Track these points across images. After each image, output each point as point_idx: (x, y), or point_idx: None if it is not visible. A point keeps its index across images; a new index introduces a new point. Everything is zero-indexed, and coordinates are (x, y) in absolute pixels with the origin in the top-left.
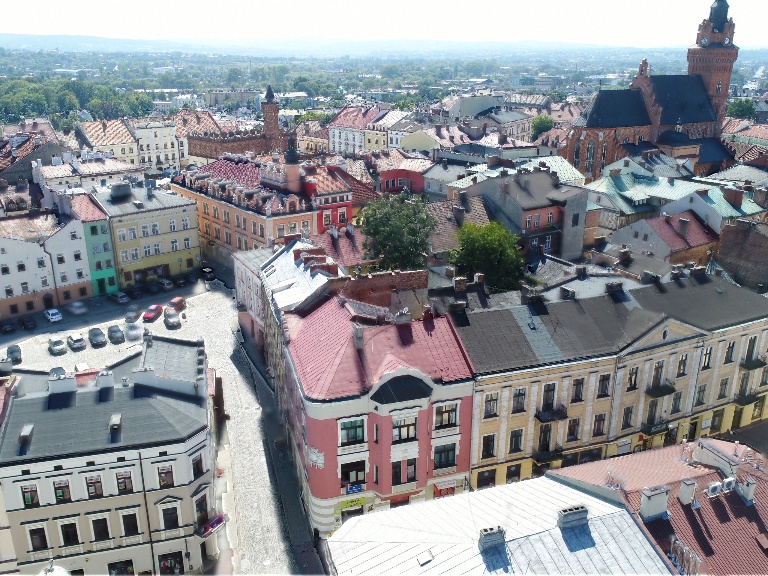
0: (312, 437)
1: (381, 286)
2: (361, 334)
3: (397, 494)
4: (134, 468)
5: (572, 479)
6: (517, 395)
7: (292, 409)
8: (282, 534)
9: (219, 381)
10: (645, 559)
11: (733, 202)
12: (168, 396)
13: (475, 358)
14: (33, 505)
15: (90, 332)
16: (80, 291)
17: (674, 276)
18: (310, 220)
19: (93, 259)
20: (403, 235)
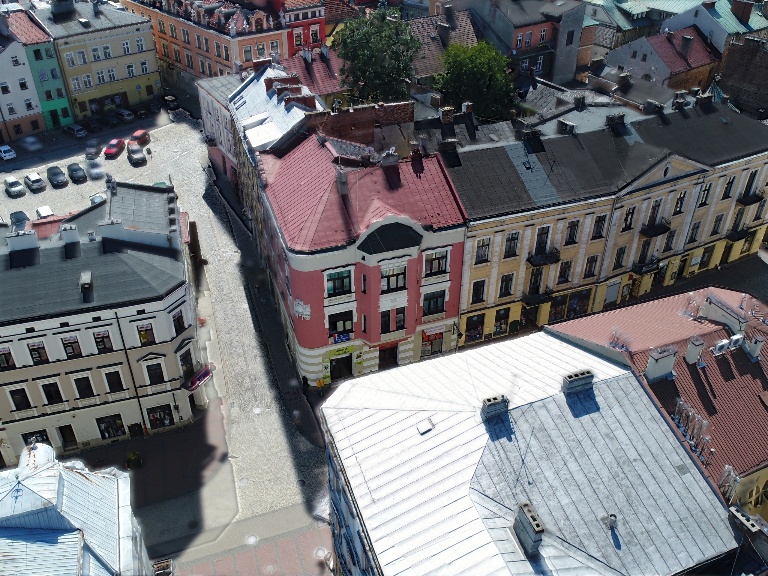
0: (297, 289)
1: (363, 121)
2: (345, 179)
3: (386, 342)
4: (111, 327)
5: (573, 337)
6: (510, 239)
7: (273, 256)
8: (270, 381)
9: (193, 225)
10: (649, 422)
11: (740, 16)
12: (140, 250)
13: (467, 202)
14: (9, 367)
15: (48, 171)
16: (32, 124)
17: (679, 105)
18: (279, 40)
19: (41, 88)
20: (385, 59)
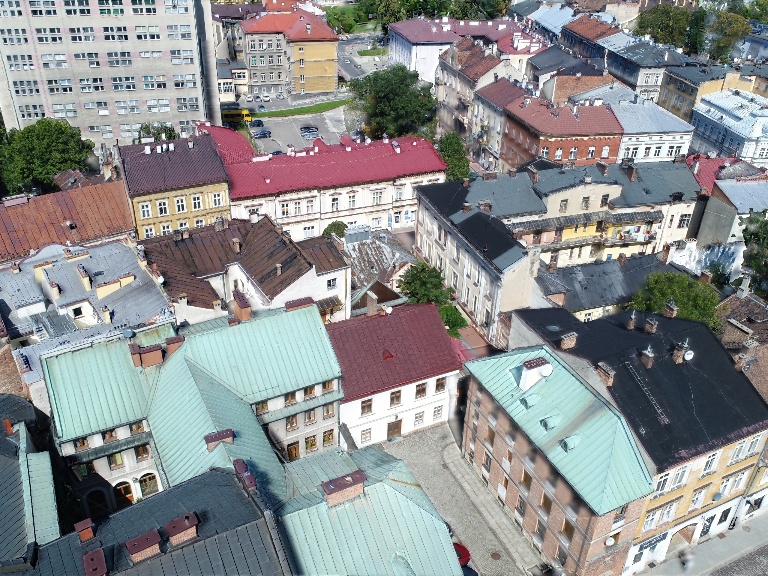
0: None
1: None
2: None
3: None
4: None
5: None
6: None
7: None
8: None
9: None
10: None
11: None
12: None
13: None
14: None
15: None
16: None
17: None
18: None
19: None
20: None
